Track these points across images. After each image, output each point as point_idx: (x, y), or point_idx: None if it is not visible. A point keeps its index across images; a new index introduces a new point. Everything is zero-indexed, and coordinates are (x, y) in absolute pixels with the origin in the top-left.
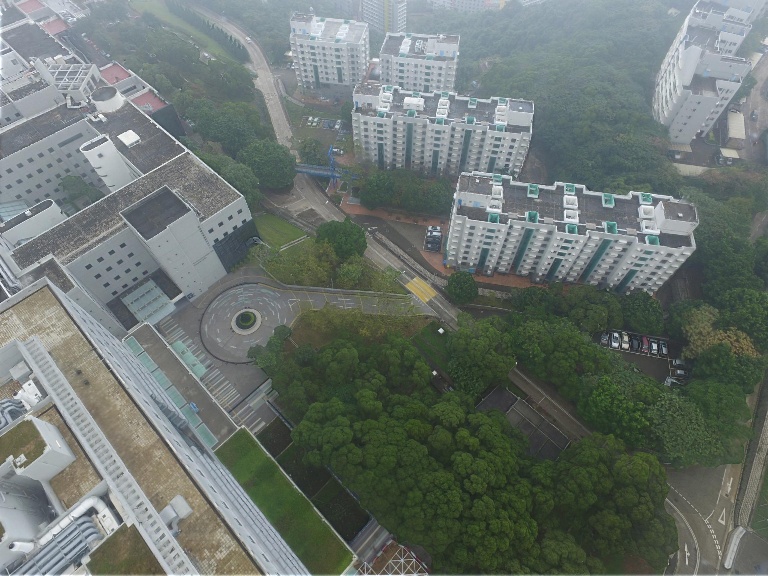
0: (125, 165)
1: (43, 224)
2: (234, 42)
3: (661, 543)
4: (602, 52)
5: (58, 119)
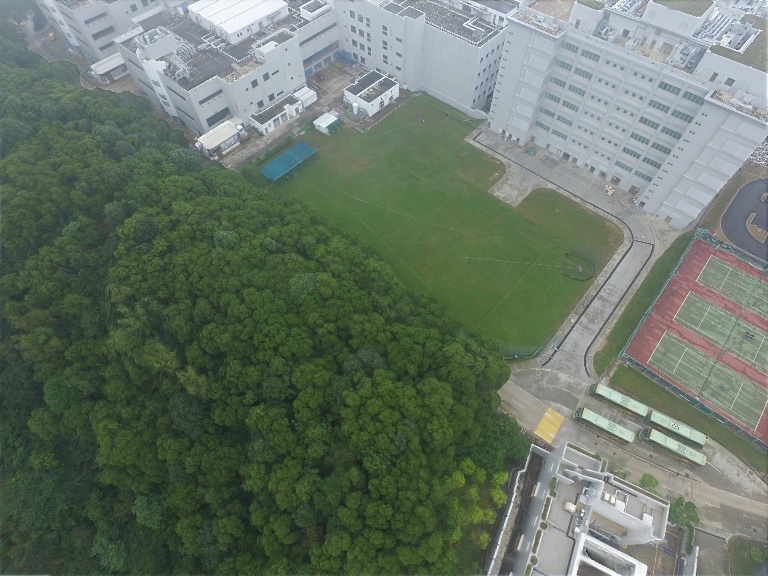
0: None
1: None
2: None
3: None
4: None
5: None
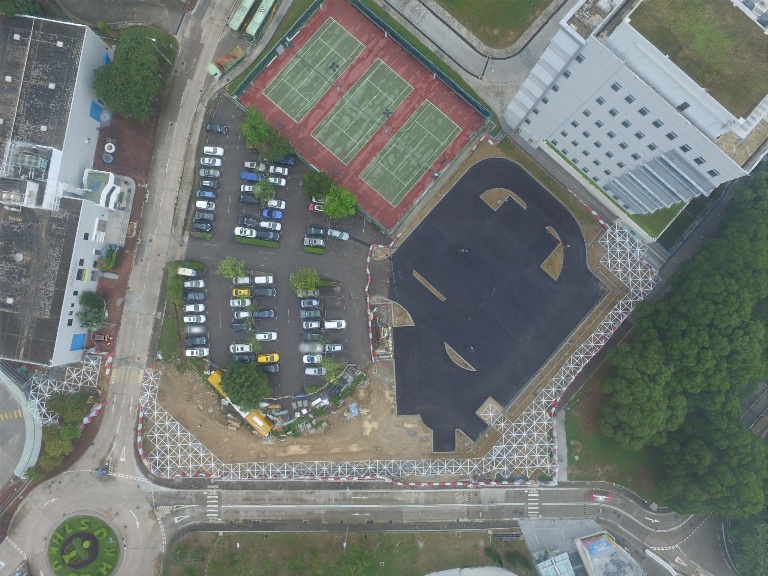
0: None
1: None
2: None
3: (689, 496)
4: None
5: None
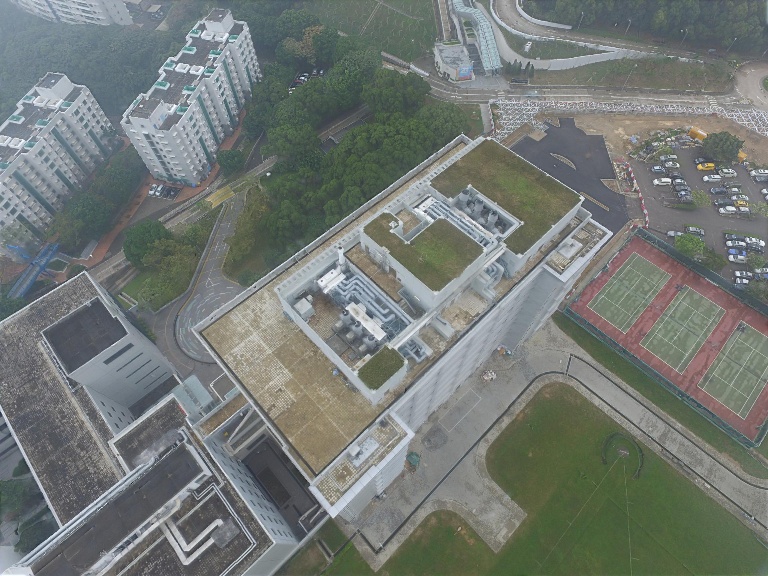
0: None
1: None
2: None
3: None
4: None
5: None
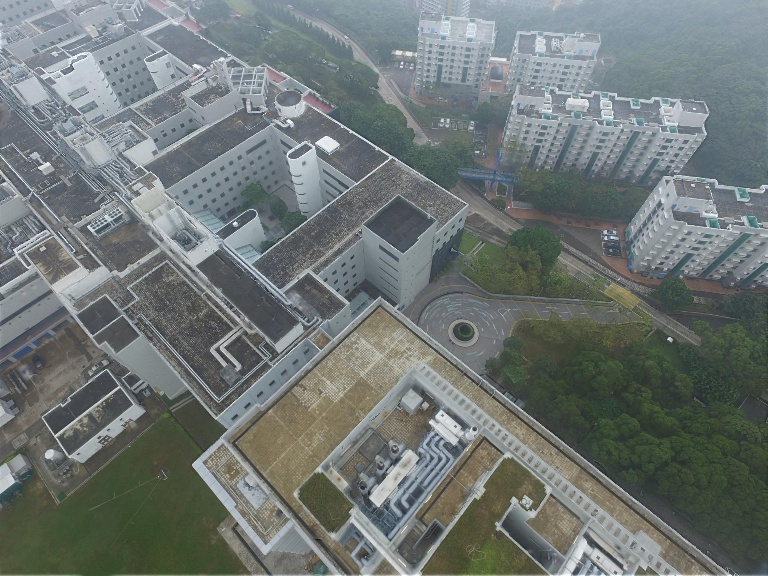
0: (318, 172)
1: (246, 235)
2: (338, 41)
3: None
4: (732, 50)
5: (241, 125)
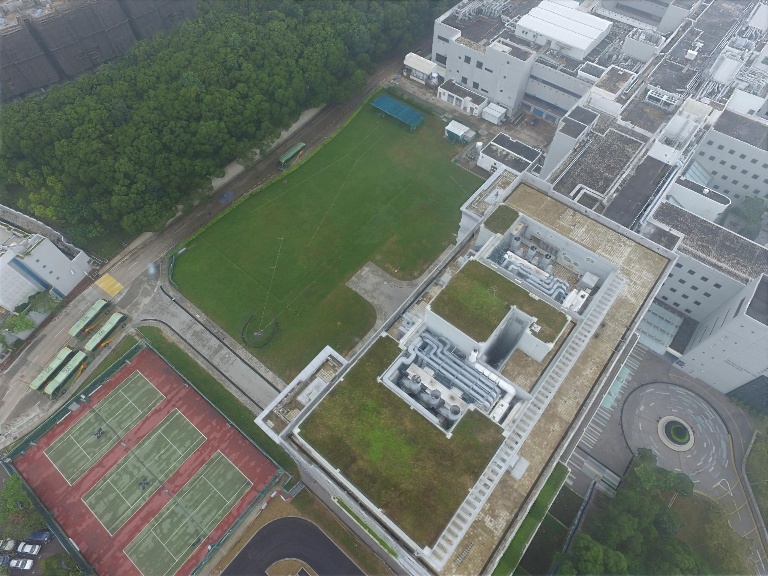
0: None
1: (698, 206)
2: None
3: None
4: None
5: None
